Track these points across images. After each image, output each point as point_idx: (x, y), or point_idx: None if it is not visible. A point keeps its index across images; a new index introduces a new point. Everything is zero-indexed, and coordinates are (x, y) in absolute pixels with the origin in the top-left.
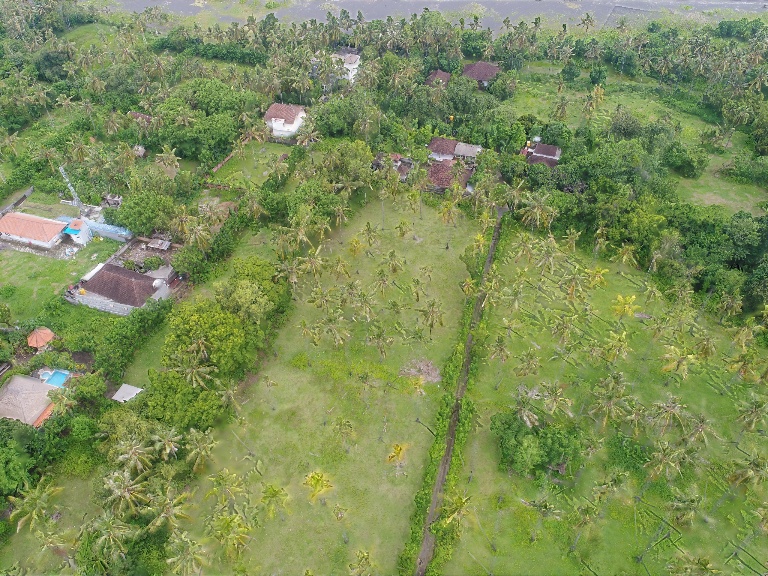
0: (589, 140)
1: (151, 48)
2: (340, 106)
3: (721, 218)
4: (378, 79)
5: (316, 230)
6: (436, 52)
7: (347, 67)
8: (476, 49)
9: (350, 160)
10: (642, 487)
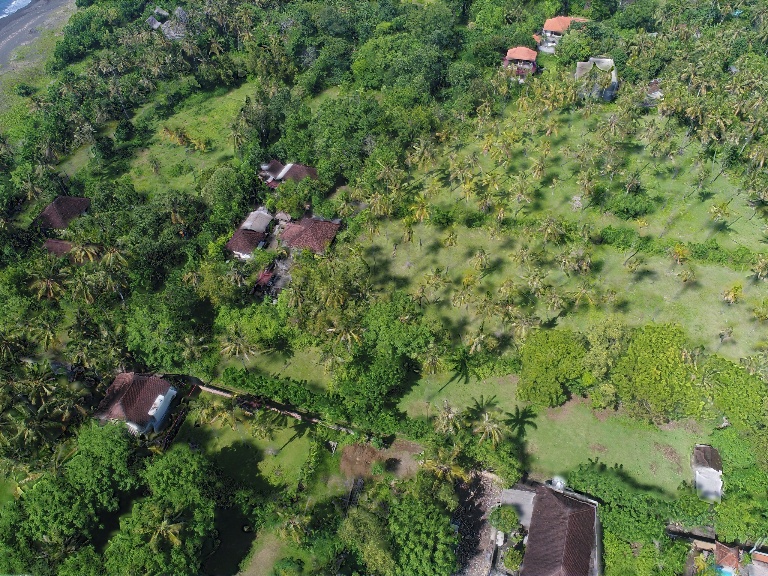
0: None
1: None
2: None
3: None
4: None
5: None
6: None
7: None
8: None
9: None
10: None
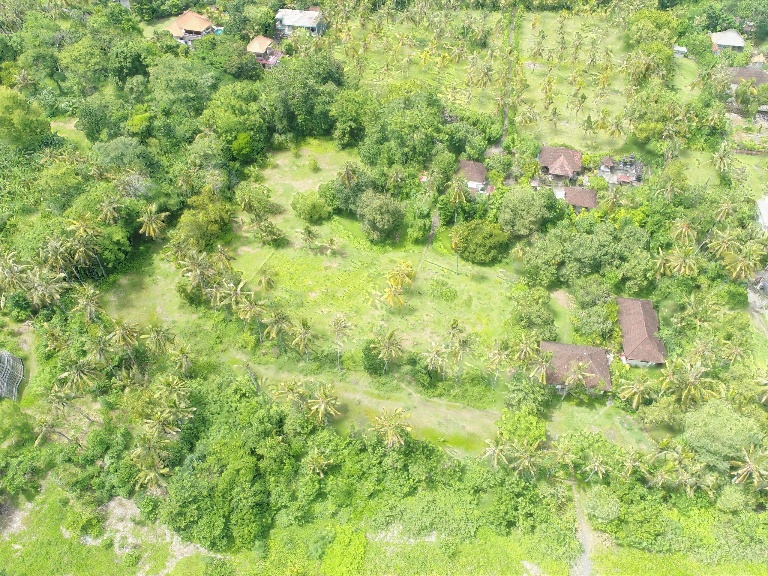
0: None
1: None
2: None
3: None
4: None
5: None
6: None
7: None
8: None
9: None
10: None
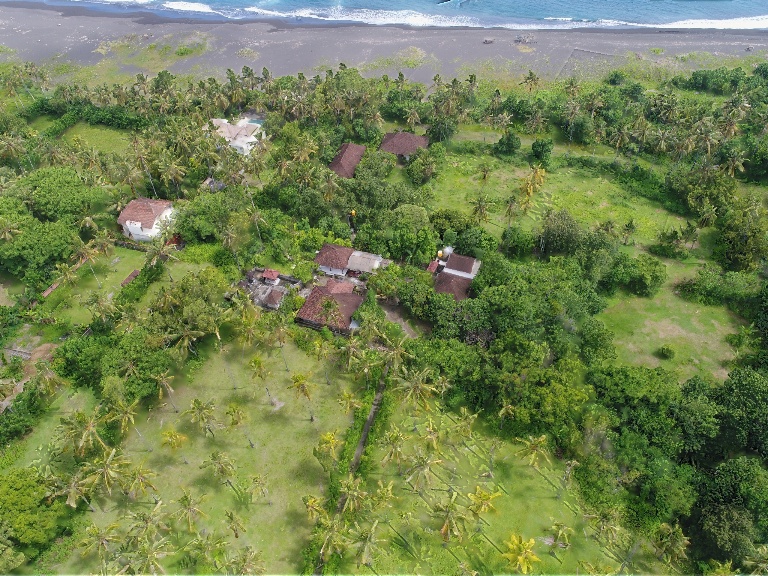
0: (518, 245)
1: (26, 112)
2: (210, 205)
3: (667, 393)
4: None
5: None
6: (351, 119)
7: (241, 141)
8: (402, 111)
9: None
10: None
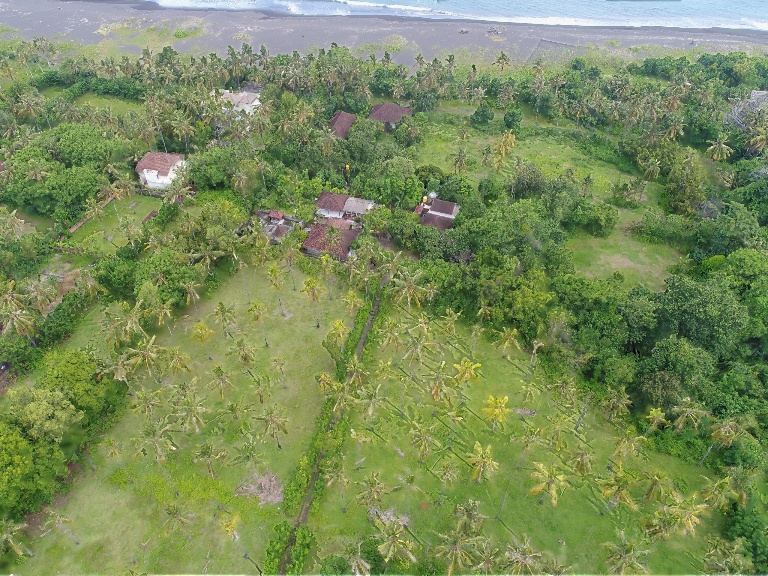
0: (492, 194)
1: (36, 82)
2: (220, 156)
3: (615, 296)
4: (275, 122)
5: (156, 314)
6: (342, 91)
7: (243, 108)
8: (388, 87)
9: (209, 227)
10: None
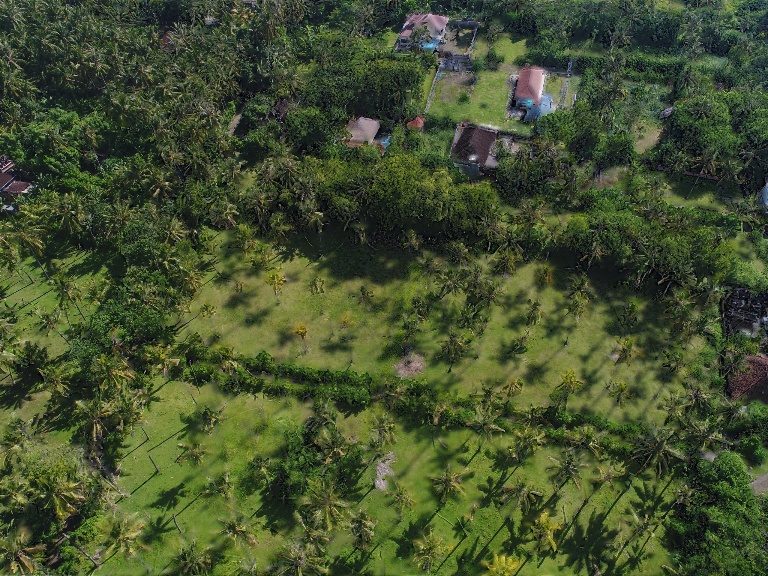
0: None
1: None
2: None
3: None
4: None
5: None
6: None
7: None
8: None
9: None
10: (266, 573)
